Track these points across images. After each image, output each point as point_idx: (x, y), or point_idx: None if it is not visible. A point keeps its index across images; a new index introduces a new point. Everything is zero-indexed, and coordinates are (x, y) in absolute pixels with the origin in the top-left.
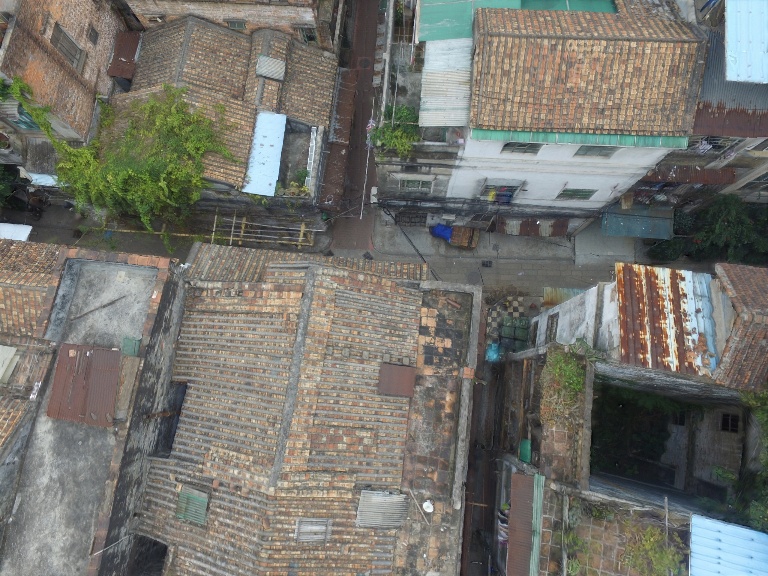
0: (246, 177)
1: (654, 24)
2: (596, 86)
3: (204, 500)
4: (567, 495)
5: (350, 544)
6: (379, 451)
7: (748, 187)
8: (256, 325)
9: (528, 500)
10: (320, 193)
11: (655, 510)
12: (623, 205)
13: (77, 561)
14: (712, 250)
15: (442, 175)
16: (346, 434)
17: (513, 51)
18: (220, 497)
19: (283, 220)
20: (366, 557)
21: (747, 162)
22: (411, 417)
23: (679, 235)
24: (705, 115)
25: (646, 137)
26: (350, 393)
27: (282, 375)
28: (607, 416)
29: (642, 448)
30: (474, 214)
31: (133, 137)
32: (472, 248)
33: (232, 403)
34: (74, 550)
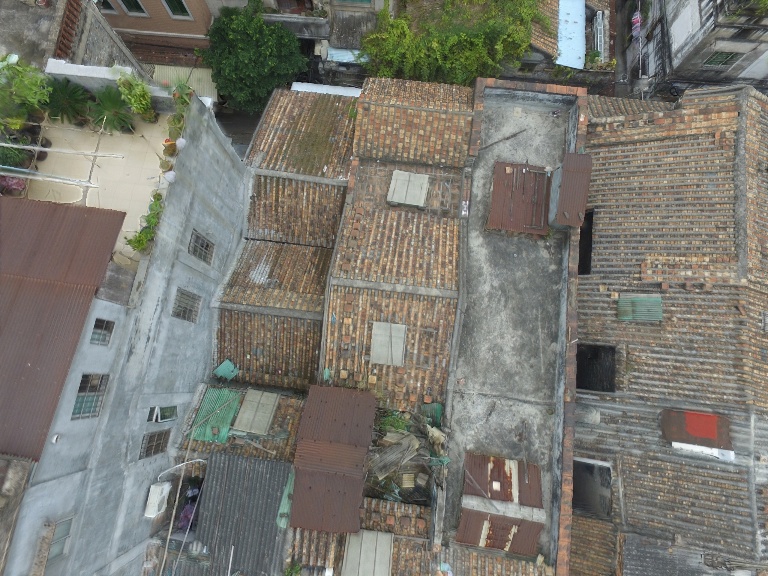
0: (557, 50)
1: None
2: None
3: (658, 299)
4: None
5: None
6: None
7: None
8: (678, 148)
9: None
10: None
11: None
12: None
13: (529, 359)
14: None
15: (766, 43)
16: None
17: None
18: (671, 298)
19: None
20: None
21: None
22: None
23: None
24: None
25: None
26: None
27: (724, 187)
28: None
29: None
30: None
31: (453, 7)
32: None
33: (662, 218)
34: (525, 350)
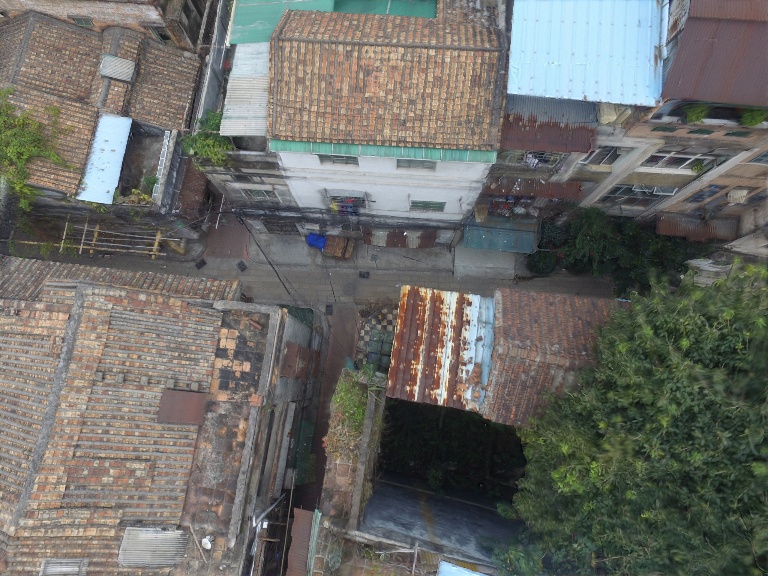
0: (82, 184)
1: (464, 30)
2: (396, 96)
3: None
4: None
5: None
6: (155, 484)
7: (607, 201)
8: (28, 347)
9: (306, 538)
10: (177, 200)
11: (421, 552)
12: (476, 218)
13: None
14: (584, 264)
15: (278, 185)
16: (114, 467)
17: (307, 57)
18: None
19: (138, 228)
20: None
21: (588, 176)
22: (199, 446)
23: (542, 249)
24: (515, 128)
25: (452, 151)
26: (123, 422)
27: (43, 403)
28: (472, 435)
29: (506, 469)
30: (341, 224)
31: None
32: (346, 258)
33: None
34: None
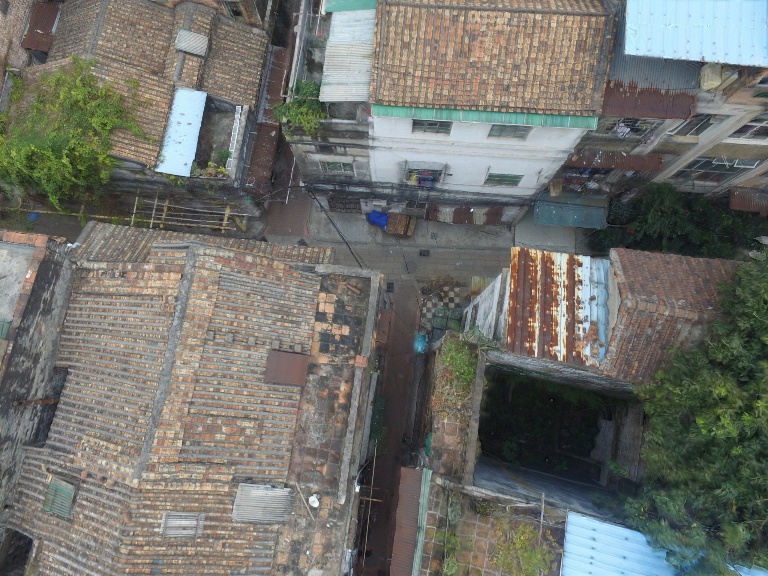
0: (160, 156)
1: None
2: (500, 61)
3: (70, 492)
4: (450, 490)
5: (225, 540)
6: (263, 442)
7: (681, 176)
8: (137, 308)
9: (415, 495)
10: (246, 176)
11: (539, 507)
12: (552, 192)
13: None
14: (650, 241)
15: (360, 157)
16: (225, 424)
17: (413, 22)
18: (88, 489)
19: (207, 203)
20: (242, 554)
21: (672, 148)
22: (302, 407)
23: (612, 225)
24: (616, 94)
25: (554, 116)
26: (233, 381)
27: (157, 361)
28: (538, 410)
29: (572, 443)
30: (407, 200)
31: (40, 111)
32: (408, 236)
33: (108, 390)
34: None
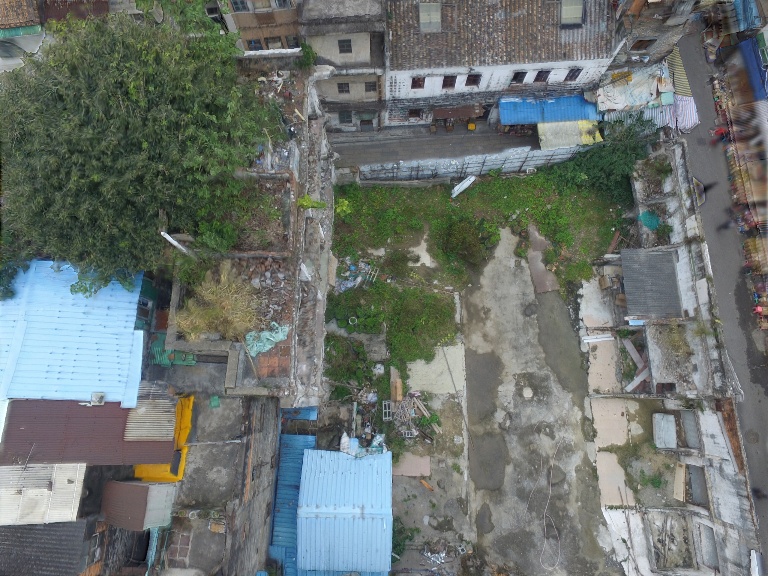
0: None
1: None
2: None
3: None
4: None
5: None
6: None
7: None
8: None
9: None
10: None
11: None
12: None
13: None
14: None
15: None
16: None
17: None
18: None
19: None
20: None
21: None
22: None
23: None
24: (52, 8)
25: (9, 29)
26: None
27: None
28: None
29: None
30: None
31: None
32: None
33: None
34: None
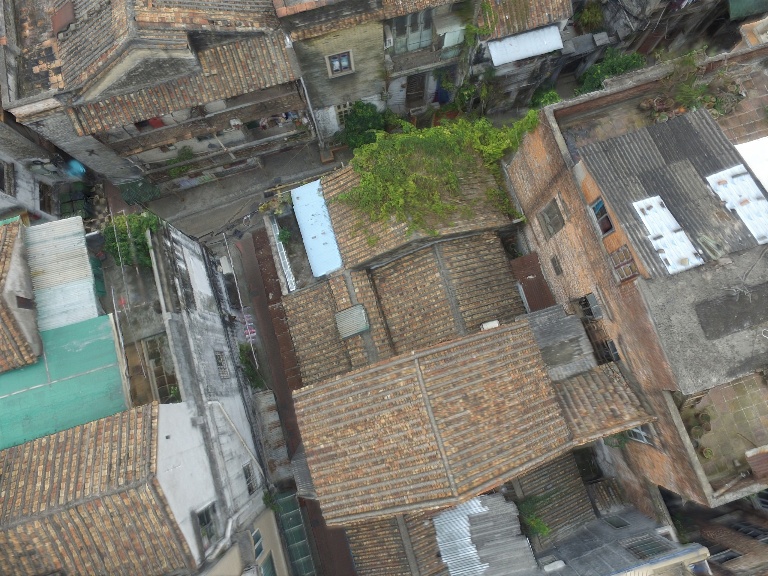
0: None
1: None
2: None
3: None
4: None
5: None
6: None
7: None
8: (183, 1)
9: None
10: None
11: None
12: None
13: None
14: None
15: None
16: None
17: None
18: None
19: None
20: None
21: None
22: (53, 8)
23: None
24: None
25: None
26: None
27: None
28: None
29: None
30: None
31: None
32: None
33: None
34: None
